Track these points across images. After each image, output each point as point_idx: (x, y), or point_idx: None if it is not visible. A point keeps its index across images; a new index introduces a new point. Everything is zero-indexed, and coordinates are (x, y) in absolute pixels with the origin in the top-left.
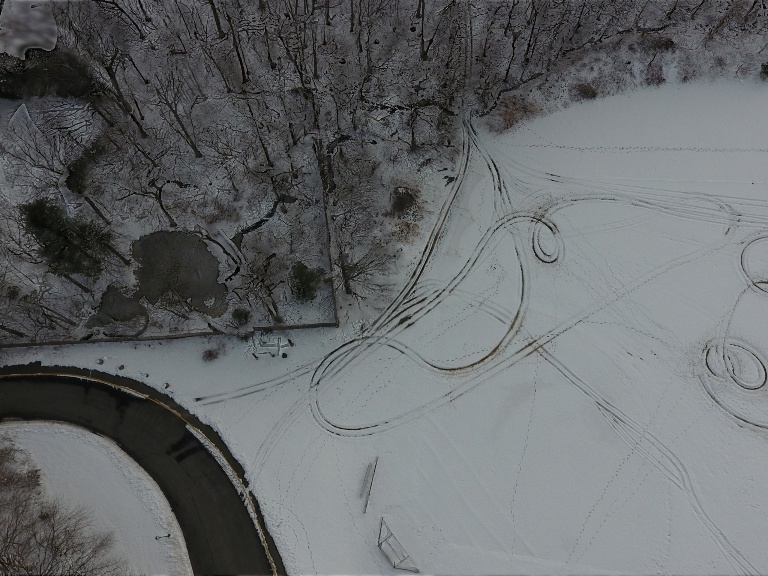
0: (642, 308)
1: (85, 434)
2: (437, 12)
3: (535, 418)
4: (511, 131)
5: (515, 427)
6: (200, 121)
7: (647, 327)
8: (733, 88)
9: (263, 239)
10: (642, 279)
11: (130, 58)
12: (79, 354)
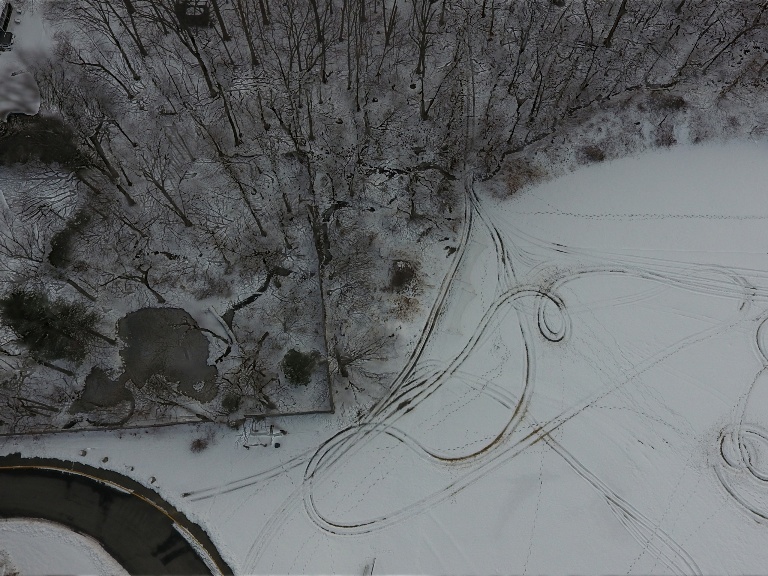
0: (653, 391)
1: (66, 533)
2: (438, 68)
3: (541, 513)
4: (515, 197)
5: (520, 523)
6: (190, 187)
7: (658, 412)
8: (747, 149)
9: (255, 316)
10: (653, 359)
11: (117, 124)
12: (61, 444)
